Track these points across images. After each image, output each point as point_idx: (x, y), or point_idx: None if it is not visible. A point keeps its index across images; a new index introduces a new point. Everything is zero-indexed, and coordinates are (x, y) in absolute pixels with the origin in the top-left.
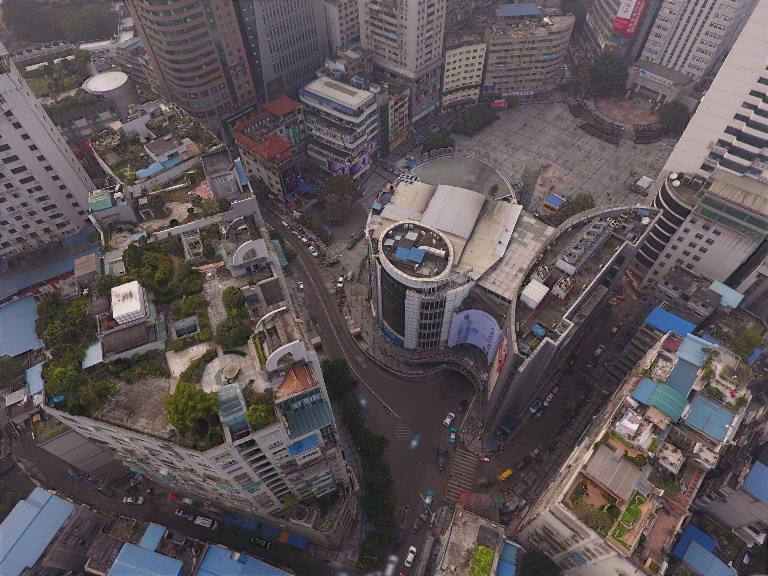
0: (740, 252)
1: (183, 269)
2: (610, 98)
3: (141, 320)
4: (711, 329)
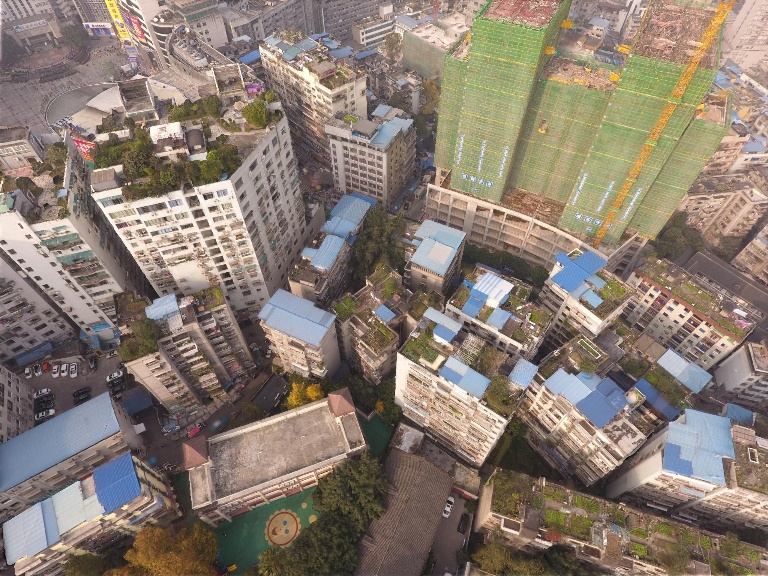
0: (220, 25)
1: None
2: (21, 60)
3: (184, 133)
4: None
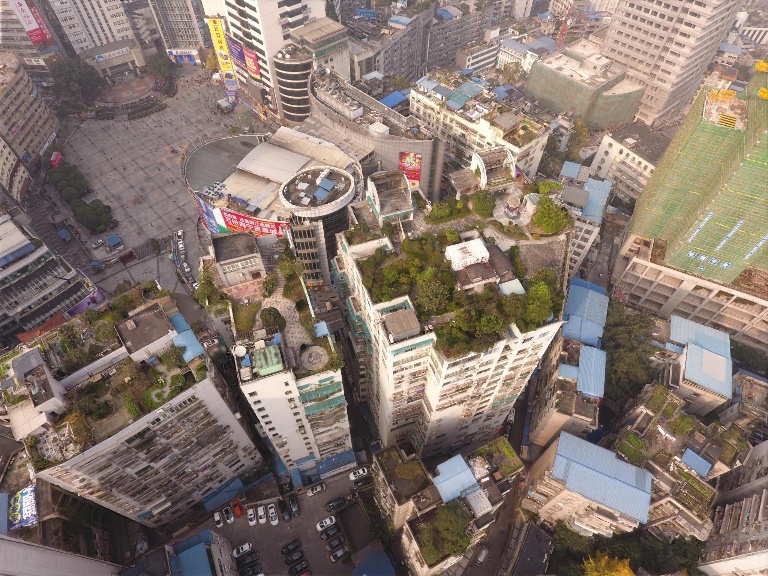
0: (346, 60)
1: (411, 242)
2: (102, 93)
3: None
4: None
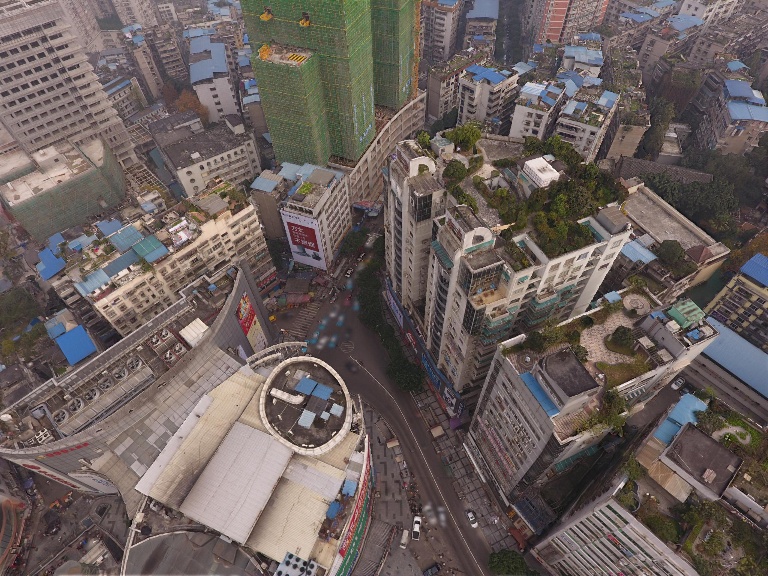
0: None
1: None
2: None
3: None
4: (34, 361)
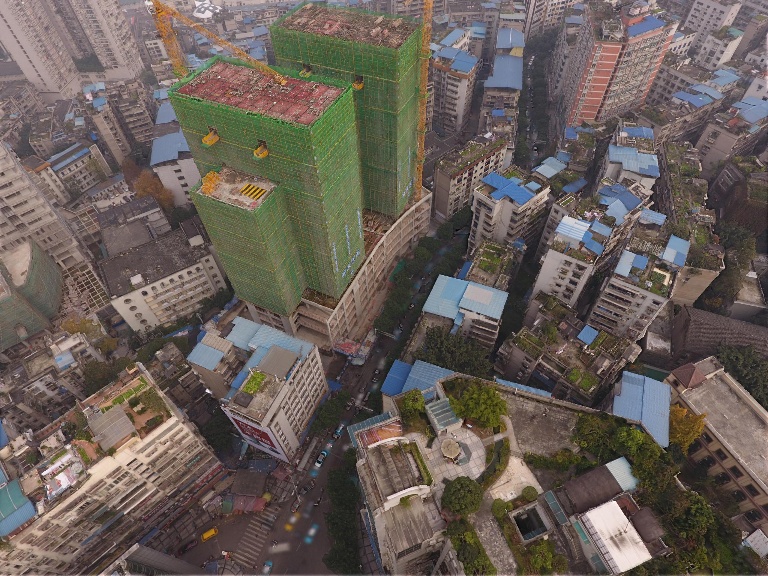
0: None
1: None
2: None
3: None
4: None
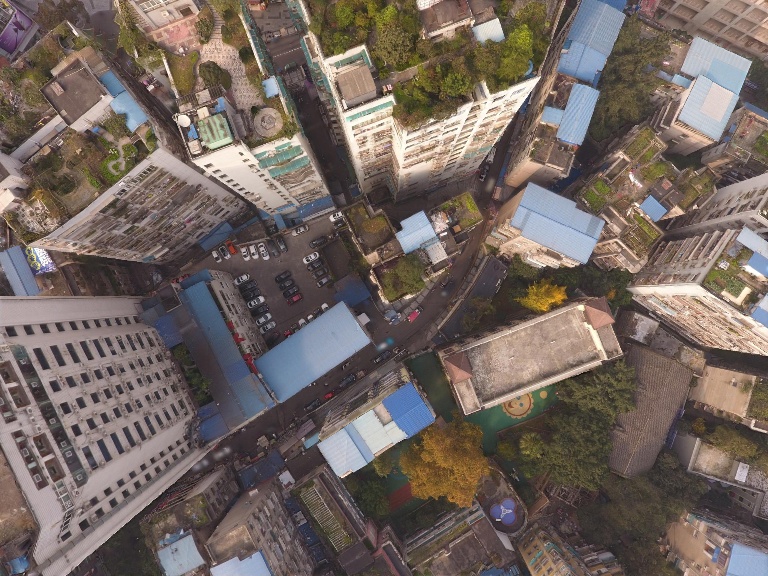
0: None
1: None
2: None
3: None
4: None
